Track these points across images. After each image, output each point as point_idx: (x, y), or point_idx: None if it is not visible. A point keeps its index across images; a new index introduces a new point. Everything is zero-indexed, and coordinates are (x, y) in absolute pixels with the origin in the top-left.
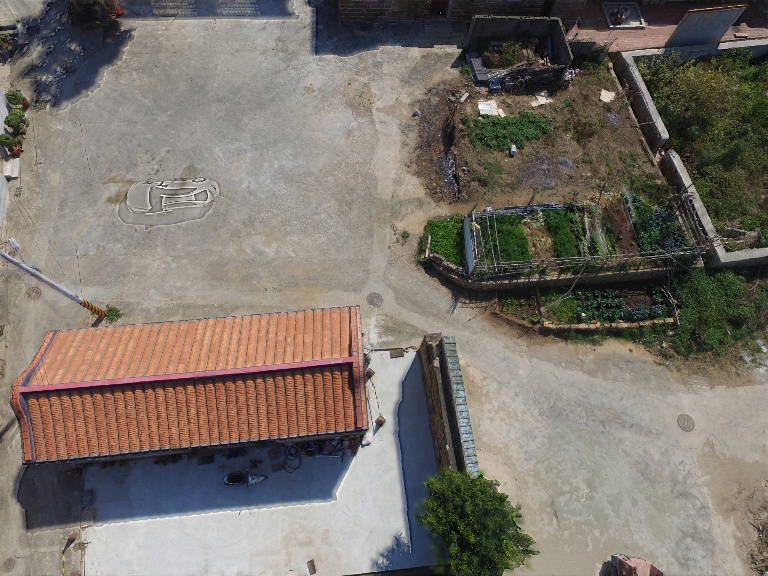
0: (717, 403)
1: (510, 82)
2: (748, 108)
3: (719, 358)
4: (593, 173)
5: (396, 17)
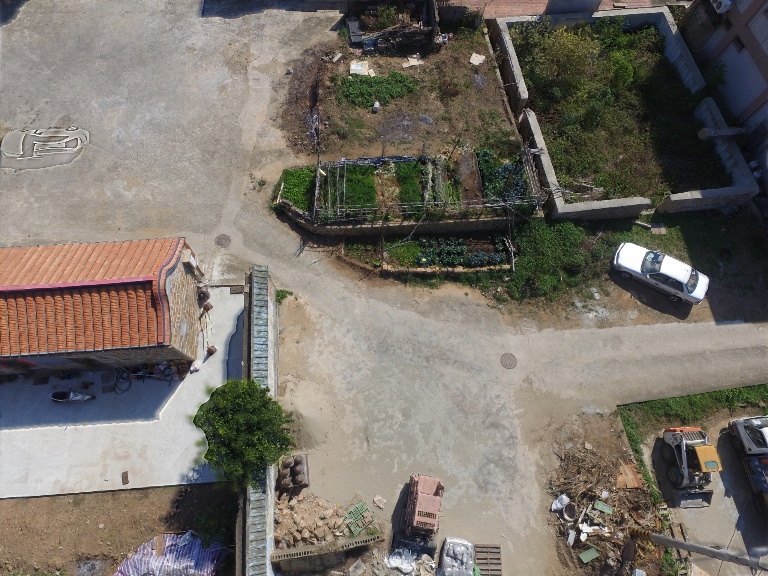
0: (542, 344)
1: (382, 44)
2: None
3: (551, 303)
4: (450, 129)
5: None
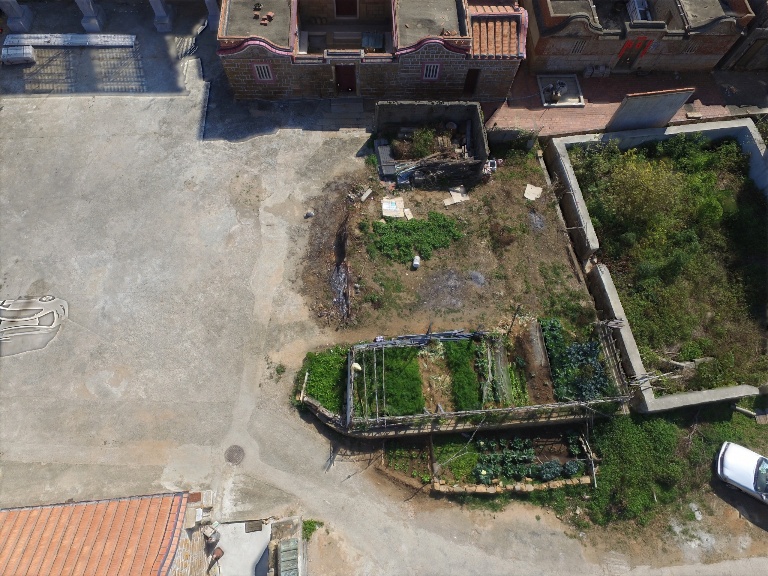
0: None
1: (420, 177)
2: (697, 205)
3: (643, 528)
4: (507, 291)
5: (298, 95)
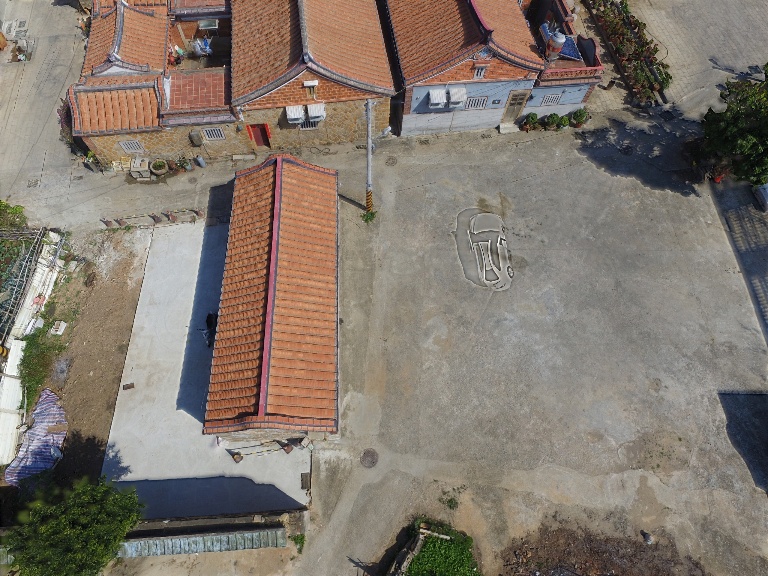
0: None
1: None
2: None
3: None
4: None
5: None
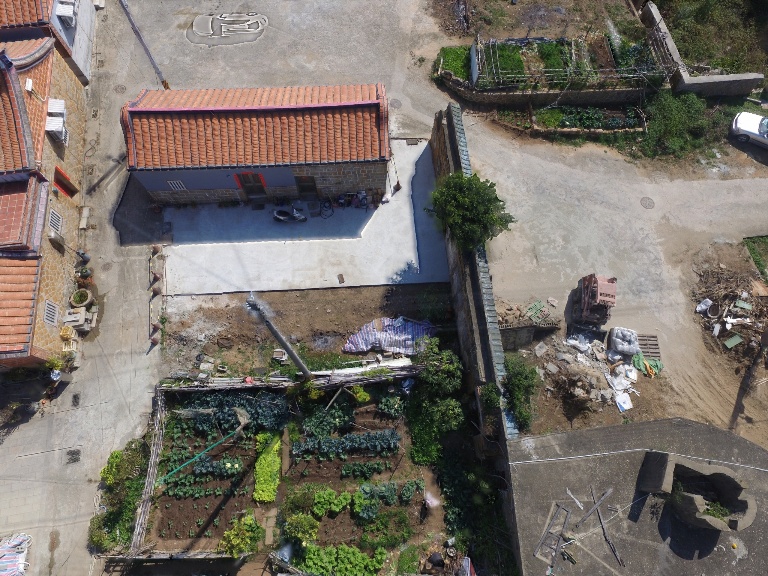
0: (675, 191)
1: None
2: None
3: (679, 160)
4: (582, 18)
5: None
